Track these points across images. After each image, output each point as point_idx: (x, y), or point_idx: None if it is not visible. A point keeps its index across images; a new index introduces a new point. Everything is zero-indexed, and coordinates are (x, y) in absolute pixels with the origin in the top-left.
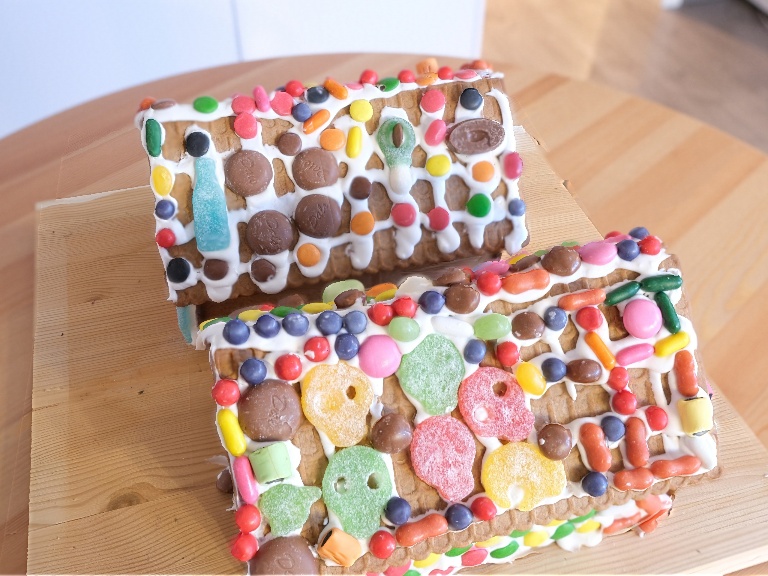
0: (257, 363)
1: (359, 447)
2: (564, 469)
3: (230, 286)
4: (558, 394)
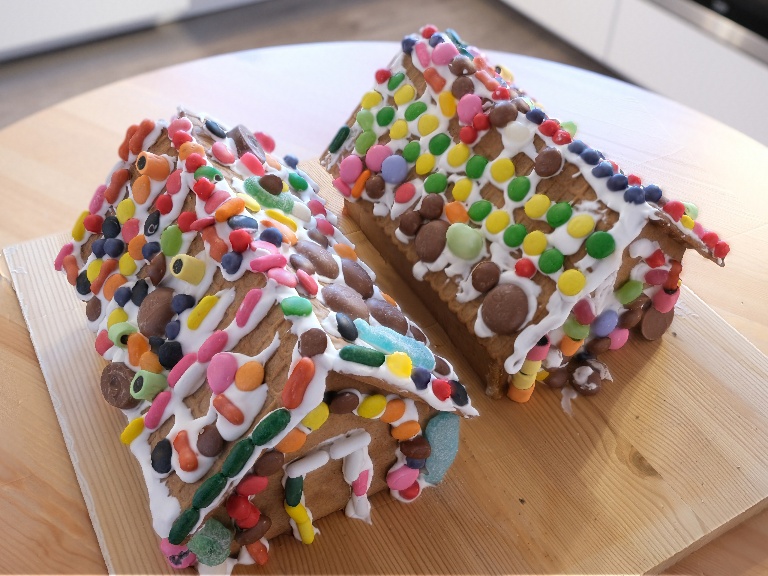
0: None
1: None
2: None
3: None
4: None
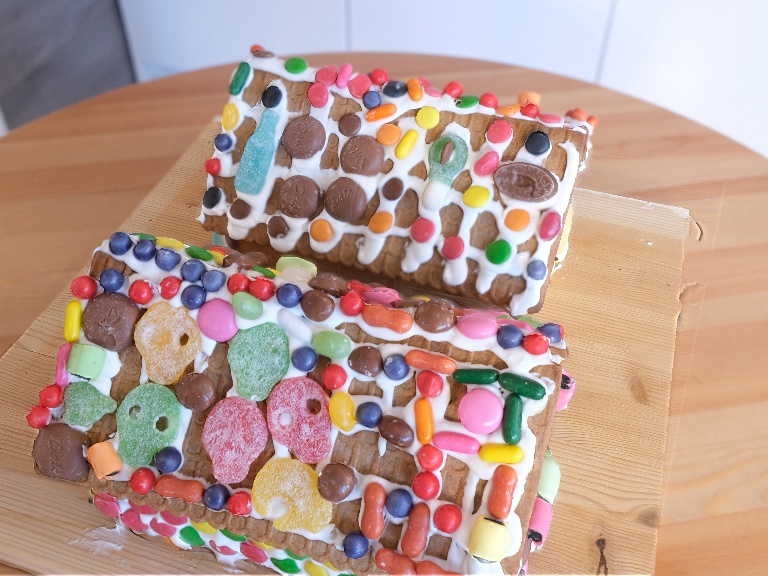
0: (112, 274)
1: (164, 388)
2: (336, 514)
3: (246, 229)
4: (370, 442)
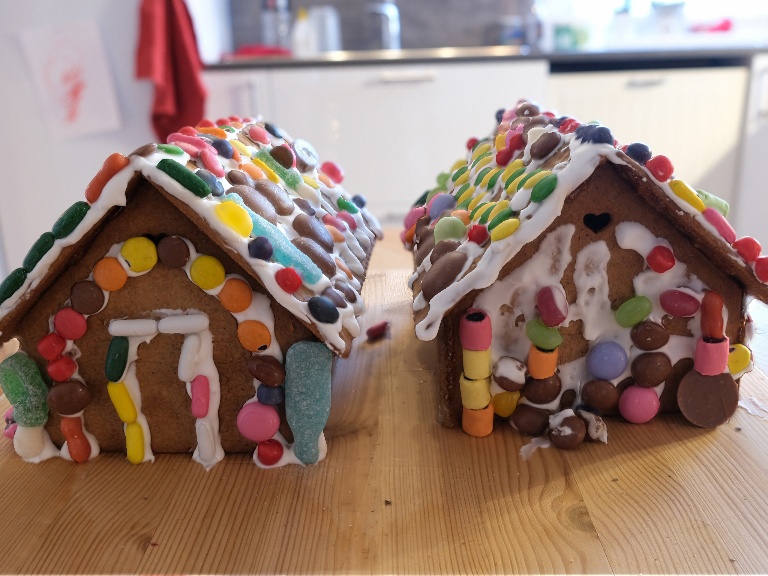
0: None
1: None
2: None
3: None
4: None
